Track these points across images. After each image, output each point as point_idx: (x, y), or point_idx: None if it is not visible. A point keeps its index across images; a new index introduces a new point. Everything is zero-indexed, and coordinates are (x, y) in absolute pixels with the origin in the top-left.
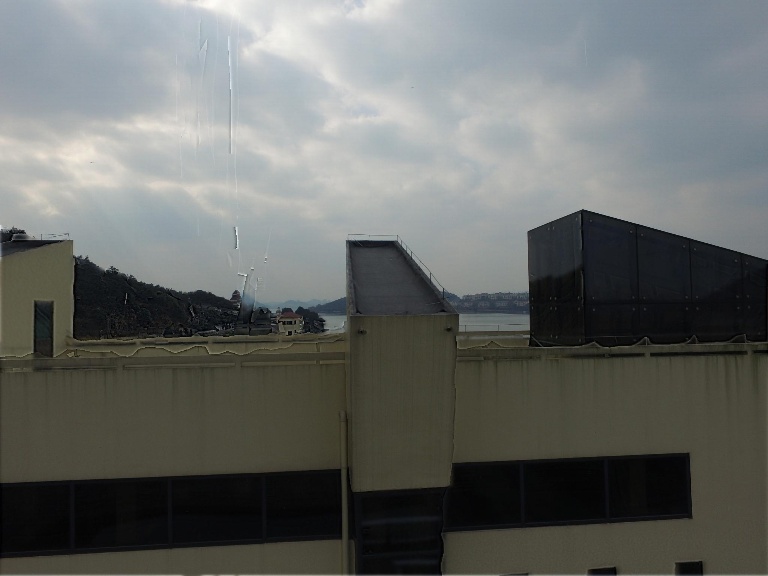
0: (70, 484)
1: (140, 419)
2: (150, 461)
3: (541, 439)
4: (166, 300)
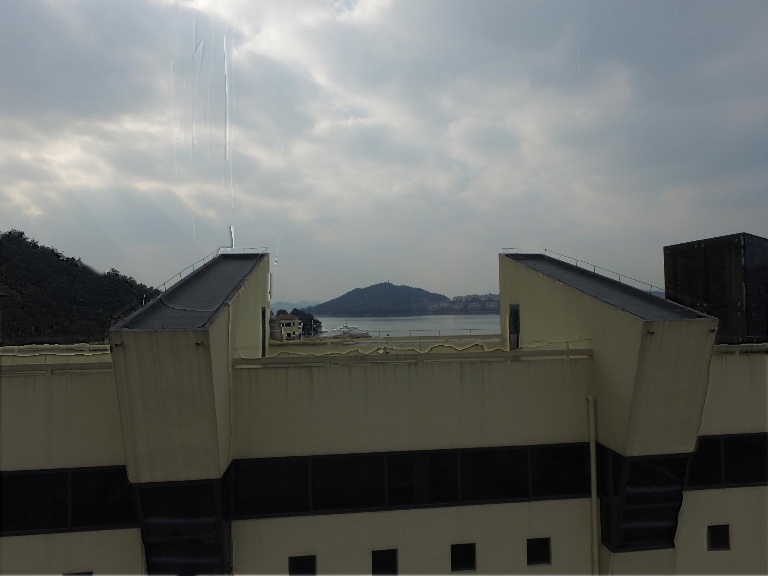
0: (384, 455)
1: (435, 403)
2: (443, 436)
3: (737, 418)
4: None
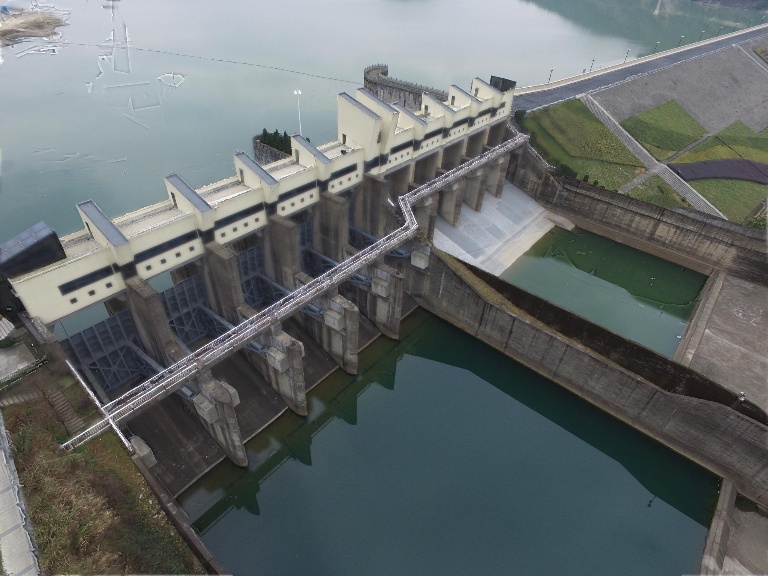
0: None
1: None
2: None
3: None
4: None
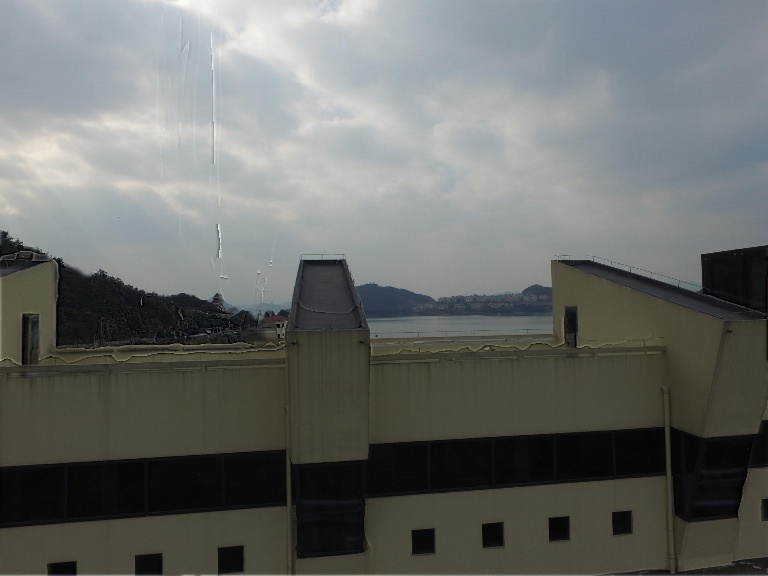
0: (491, 440)
1: (533, 394)
2: (541, 423)
3: None
4: (156, 303)
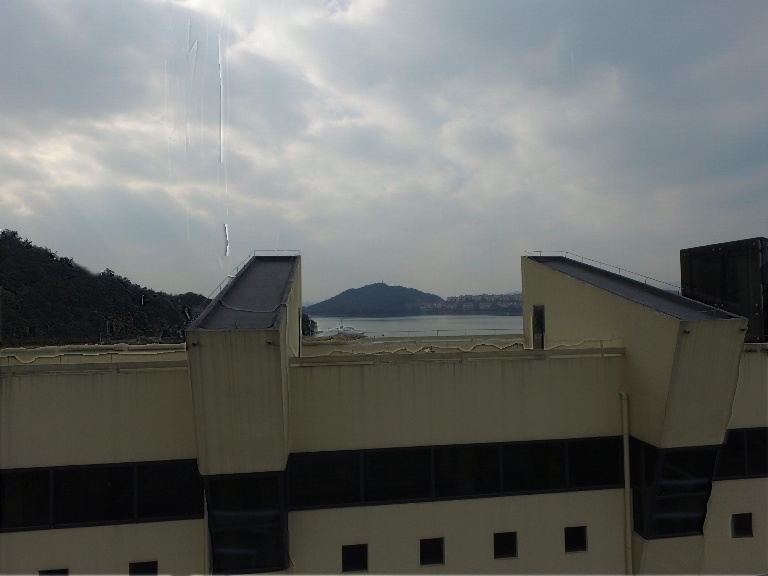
0: (431, 448)
1: (478, 399)
2: (486, 431)
3: (759, 412)
4: (162, 302)
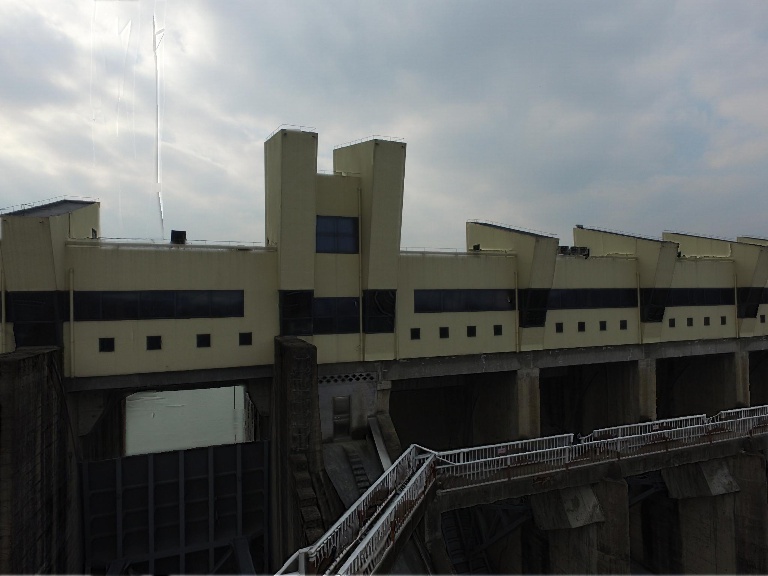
0: None
1: None
2: None
3: None
4: None
